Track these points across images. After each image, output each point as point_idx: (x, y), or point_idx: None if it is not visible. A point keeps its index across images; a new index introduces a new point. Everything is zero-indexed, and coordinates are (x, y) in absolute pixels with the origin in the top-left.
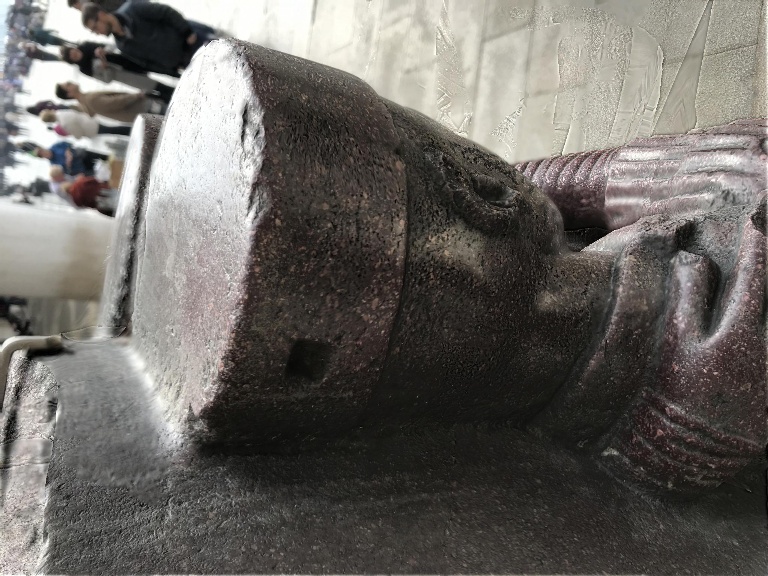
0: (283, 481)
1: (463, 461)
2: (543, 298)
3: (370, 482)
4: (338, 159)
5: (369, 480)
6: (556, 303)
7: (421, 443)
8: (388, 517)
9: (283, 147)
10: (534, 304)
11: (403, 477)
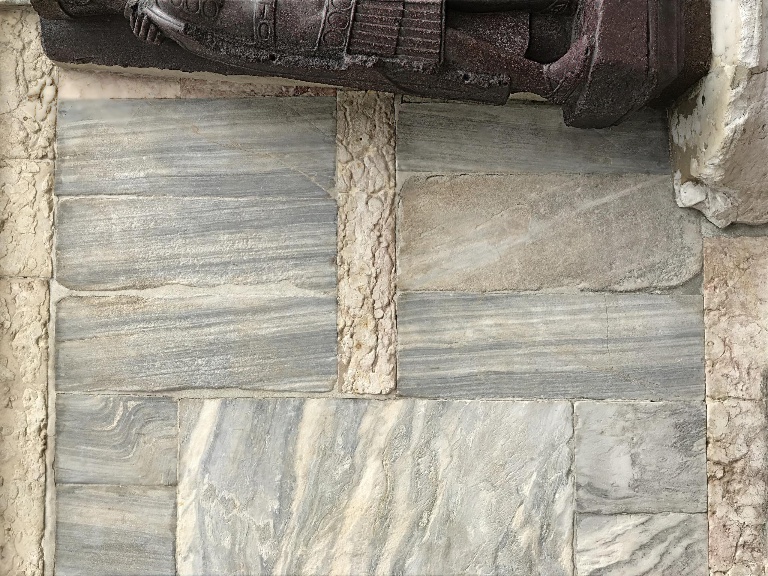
0: (73, 22)
1: (111, 21)
2: None
3: (89, 24)
4: (44, 5)
5: (89, 24)
6: (113, 8)
7: None
8: (91, 32)
9: (35, 5)
10: (107, 8)
11: (96, 24)
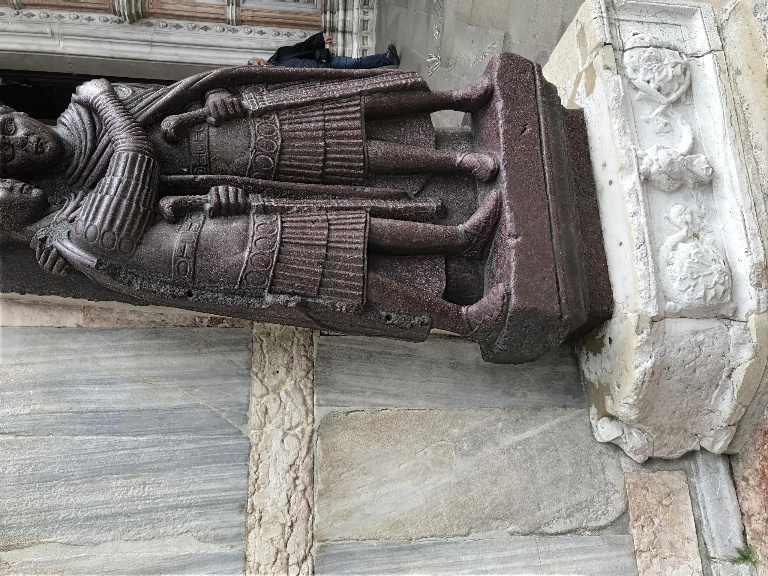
0: None
1: (13, 249)
2: (14, 237)
3: None
4: None
5: None
6: (18, 238)
7: (5, 243)
8: None
9: None
10: None
11: None
